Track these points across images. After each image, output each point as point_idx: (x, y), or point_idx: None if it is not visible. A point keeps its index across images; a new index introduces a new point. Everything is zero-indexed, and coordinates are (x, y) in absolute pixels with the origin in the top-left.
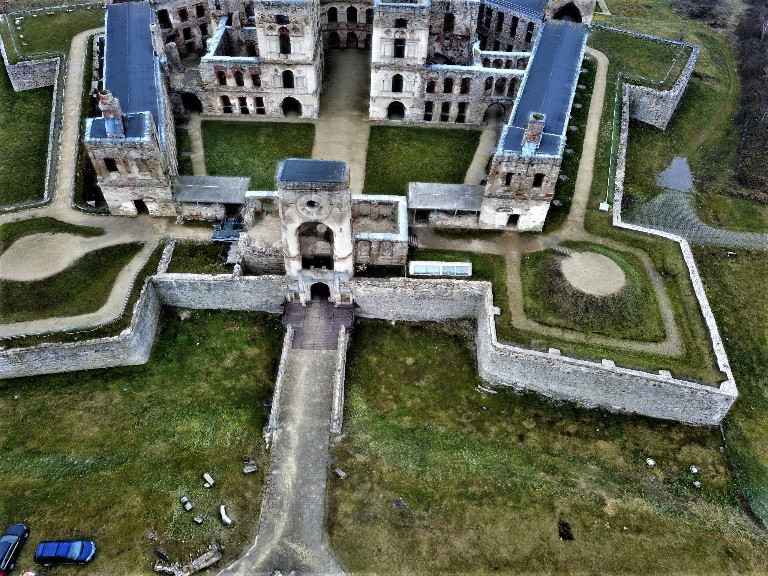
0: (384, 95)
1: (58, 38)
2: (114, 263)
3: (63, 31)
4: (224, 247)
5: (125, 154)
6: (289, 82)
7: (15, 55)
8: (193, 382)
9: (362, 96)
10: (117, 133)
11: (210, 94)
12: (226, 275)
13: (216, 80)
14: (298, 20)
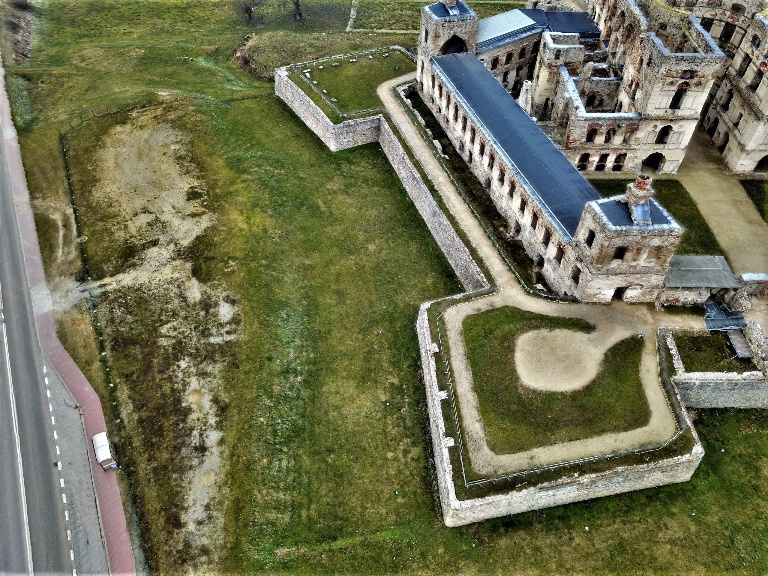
0: (761, 148)
1: (362, 92)
2: (627, 362)
3: (362, 84)
4: (722, 337)
5: (645, 242)
6: (660, 137)
7: (333, 113)
8: (748, 499)
9: (705, 146)
10: (645, 220)
11: (571, 152)
12: (754, 373)
13: (584, 138)
14: (705, 74)
